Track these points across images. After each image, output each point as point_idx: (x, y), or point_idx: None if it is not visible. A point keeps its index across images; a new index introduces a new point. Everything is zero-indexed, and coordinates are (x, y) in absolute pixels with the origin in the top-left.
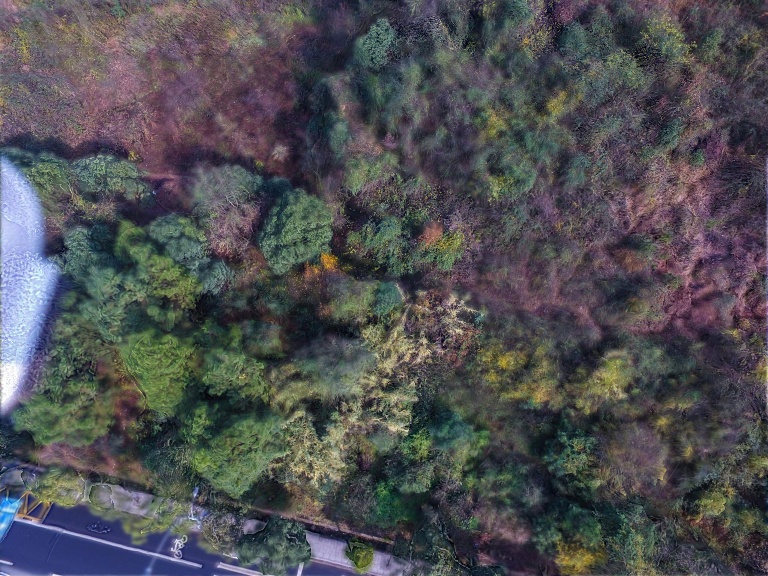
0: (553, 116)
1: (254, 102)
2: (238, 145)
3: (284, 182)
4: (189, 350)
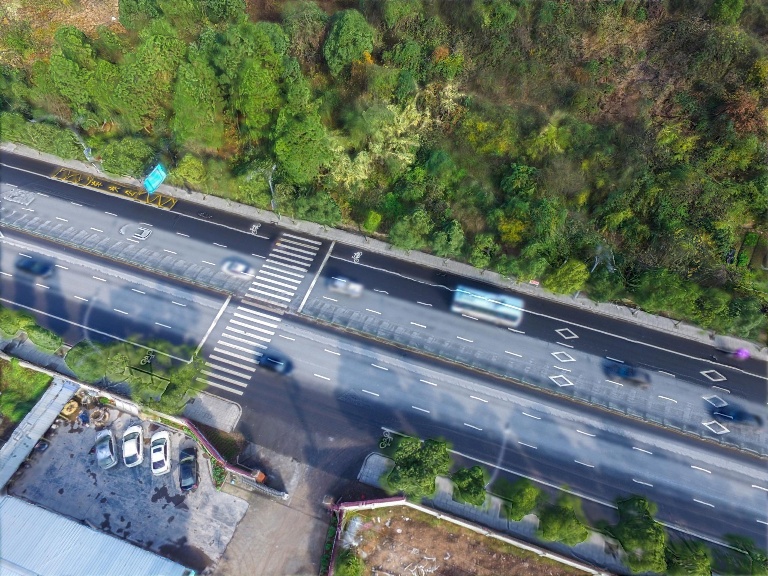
0: None
1: None
2: None
3: None
4: (276, 90)
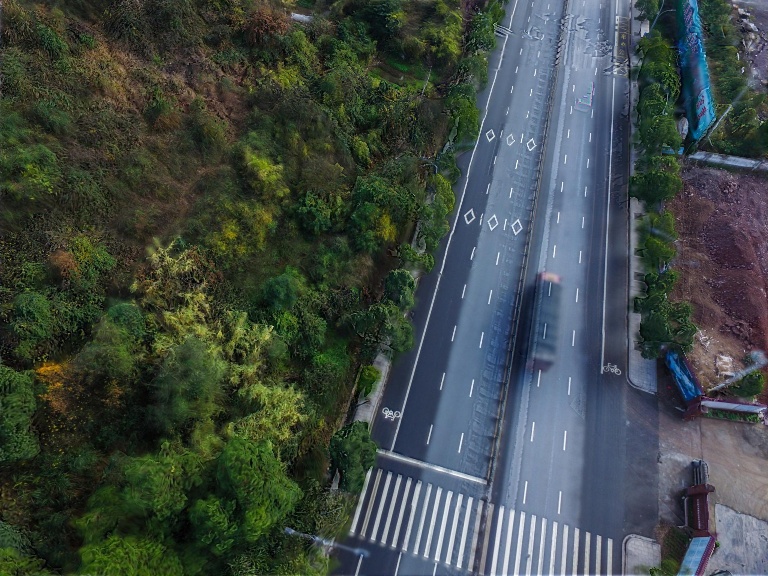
0: None
1: None
2: None
3: None
4: None
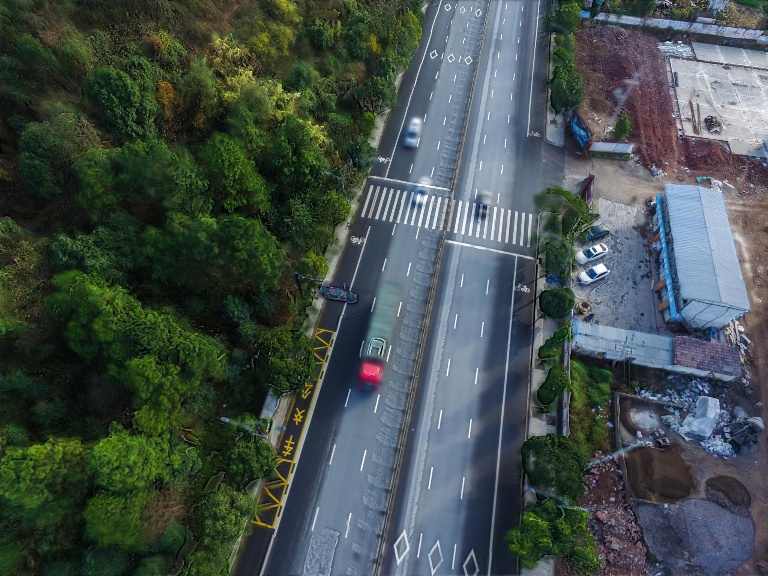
0: None
1: None
2: None
3: None
4: None
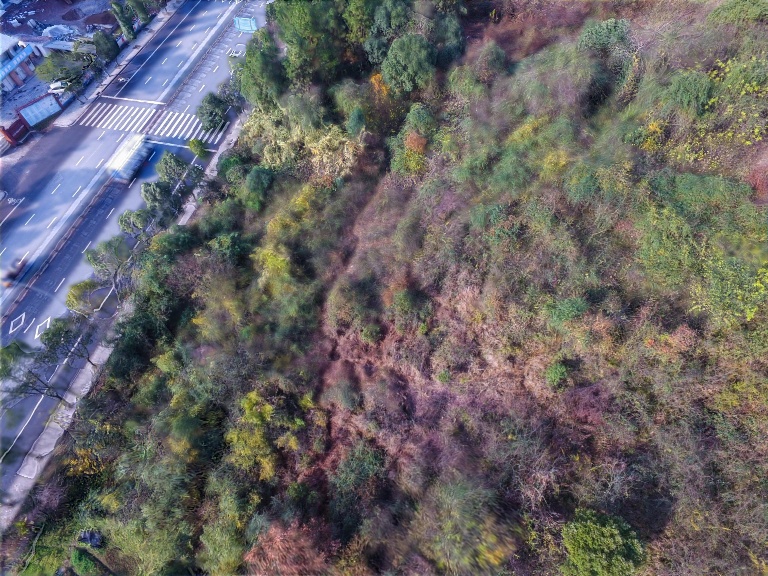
0: (544, 170)
1: None
2: None
3: (452, 52)
4: (311, 35)
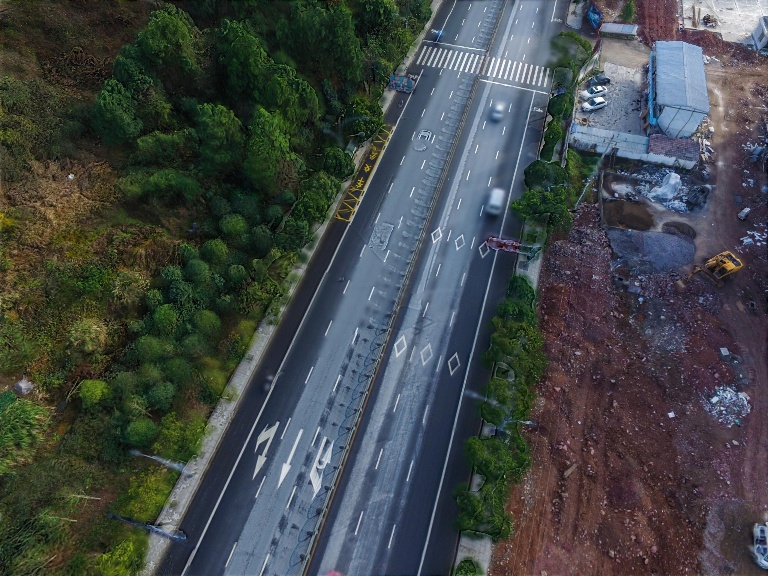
0: None
1: (89, 7)
2: (134, 21)
3: None
4: None
